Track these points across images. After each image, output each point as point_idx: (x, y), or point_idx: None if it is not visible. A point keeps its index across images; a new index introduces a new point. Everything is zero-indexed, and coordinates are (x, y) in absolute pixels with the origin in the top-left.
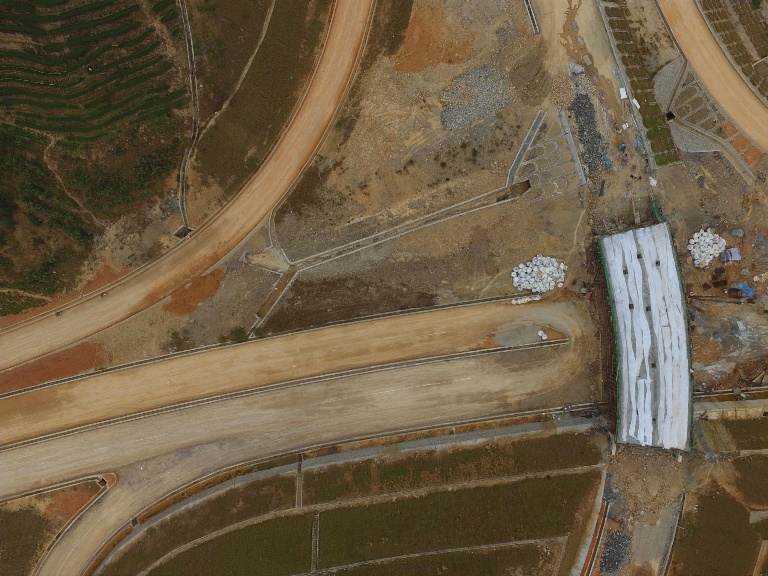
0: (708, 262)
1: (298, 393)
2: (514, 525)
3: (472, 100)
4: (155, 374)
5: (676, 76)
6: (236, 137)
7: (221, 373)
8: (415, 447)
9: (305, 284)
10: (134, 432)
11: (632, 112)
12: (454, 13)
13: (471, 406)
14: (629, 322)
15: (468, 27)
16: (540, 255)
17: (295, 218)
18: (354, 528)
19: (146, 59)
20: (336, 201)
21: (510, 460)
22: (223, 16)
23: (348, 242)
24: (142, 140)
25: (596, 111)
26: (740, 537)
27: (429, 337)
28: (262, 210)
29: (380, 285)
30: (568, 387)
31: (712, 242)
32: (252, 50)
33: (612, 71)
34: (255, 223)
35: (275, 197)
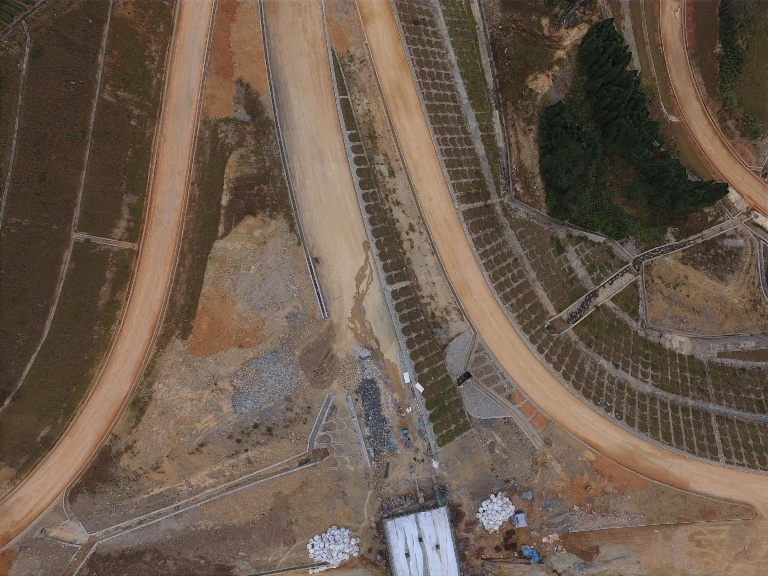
0: None
1: None
2: None
3: (261, 385)
4: None
5: (468, 344)
6: (24, 424)
7: None
8: None
9: (102, 558)
10: None
11: (415, 396)
12: (244, 300)
13: None
14: None
15: (258, 313)
16: (334, 527)
17: (89, 497)
18: None
19: None
20: (132, 478)
21: None
22: None
23: (148, 512)
24: None
25: (381, 395)
26: None
27: None
28: (56, 488)
29: (178, 558)
30: None
31: (500, 509)
32: (34, 348)
33: (396, 356)
34: (49, 502)
35: (70, 475)
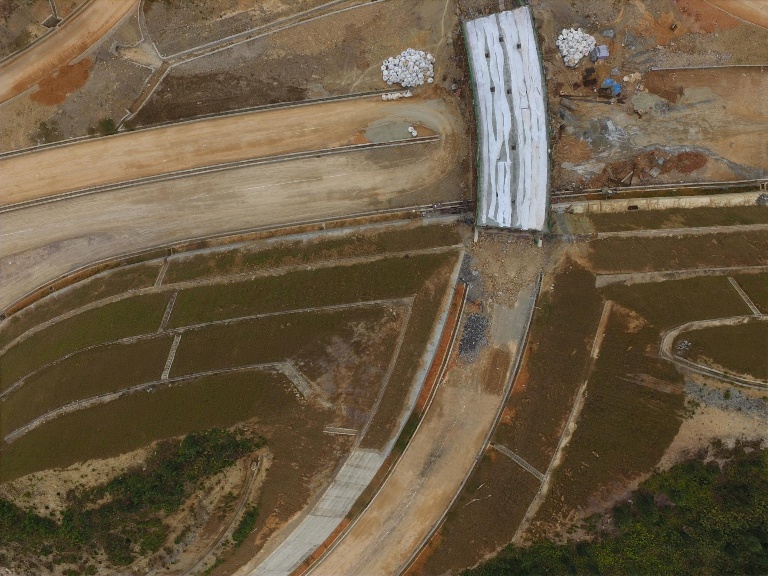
0: (577, 60)
1: (168, 188)
2: (364, 291)
3: None
4: (24, 167)
5: None
6: None
7: (91, 167)
8: (282, 238)
9: (176, 78)
10: (3, 226)
11: None
12: None
13: (342, 203)
14: (490, 105)
15: None
16: (409, 48)
17: (164, 7)
18: (208, 300)
19: None
20: None
21: (373, 246)
22: None
23: (220, 38)
24: None
25: None
26: (587, 302)
27: (300, 133)
28: None
29: (251, 79)
30: (438, 185)
31: (581, 39)
32: None
33: None
34: (124, 12)
35: None
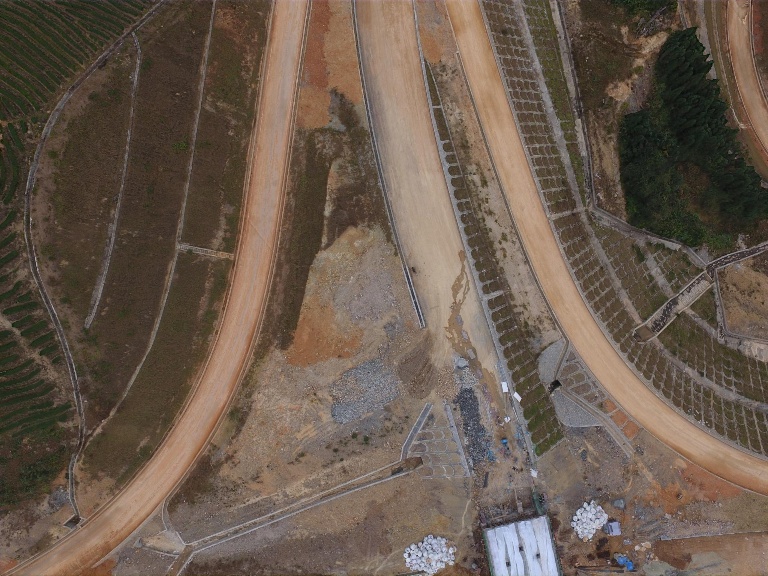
0: None
1: None
2: None
3: (361, 395)
4: None
5: (560, 353)
6: (126, 434)
7: None
8: None
9: (200, 568)
10: None
11: (513, 406)
12: (343, 310)
13: None
14: None
15: (357, 323)
16: (431, 536)
17: (188, 507)
18: None
19: (27, 383)
20: (230, 488)
21: None
22: (106, 341)
23: (244, 522)
24: (26, 449)
25: (480, 404)
26: None
27: None
28: (155, 498)
29: (275, 567)
30: None
31: (594, 517)
32: (139, 359)
33: (494, 365)
34: (148, 512)
35: (168, 485)
